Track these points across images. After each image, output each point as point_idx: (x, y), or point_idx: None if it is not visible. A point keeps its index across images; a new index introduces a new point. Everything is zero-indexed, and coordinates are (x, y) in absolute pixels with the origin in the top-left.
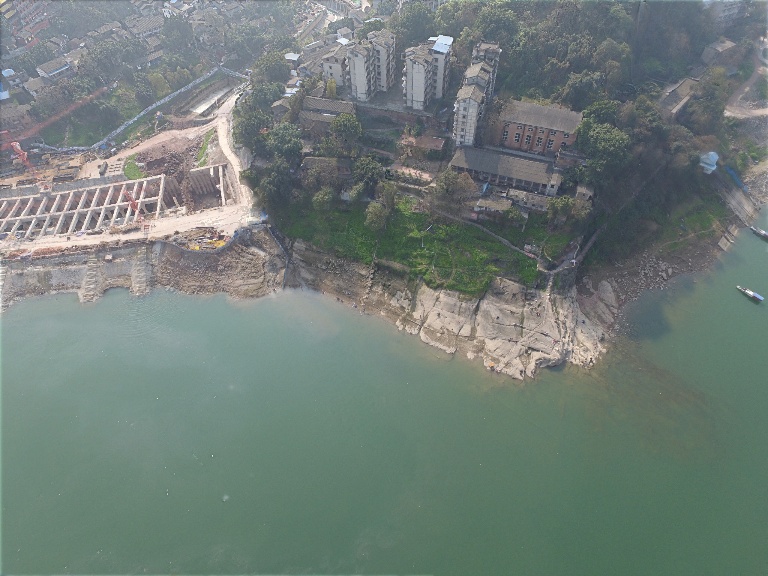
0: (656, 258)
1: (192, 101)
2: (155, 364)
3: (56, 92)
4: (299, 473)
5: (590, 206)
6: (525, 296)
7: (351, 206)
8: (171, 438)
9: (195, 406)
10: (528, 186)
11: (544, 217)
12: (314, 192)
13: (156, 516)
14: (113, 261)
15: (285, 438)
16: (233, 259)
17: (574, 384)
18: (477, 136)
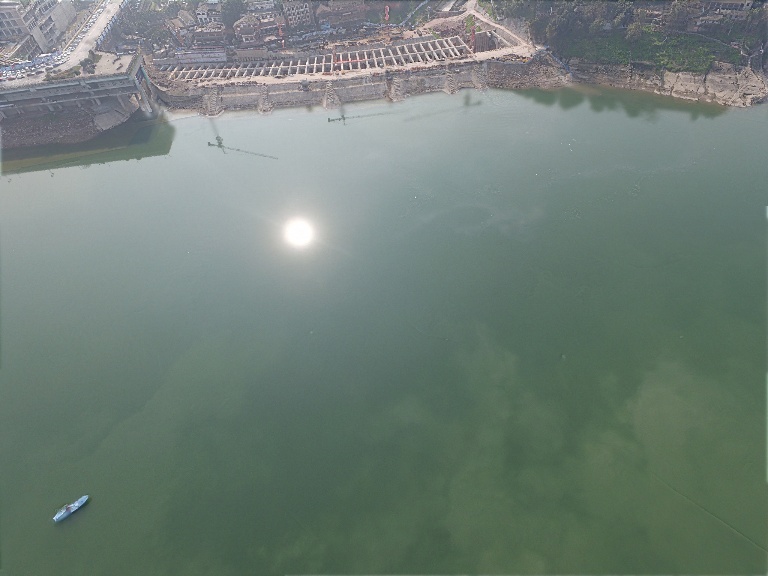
0: None
1: (440, 4)
2: (520, 112)
3: None
4: (639, 142)
5: None
6: (735, 70)
7: (609, 33)
8: (555, 135)
9: (558, 125)
10: (730, 8)
11: (743, 24)
12: (590, 23)
13: (570, 158)
14: (460, 73)
15: (620, 132)
16: (537, 68)
17: None
18: None
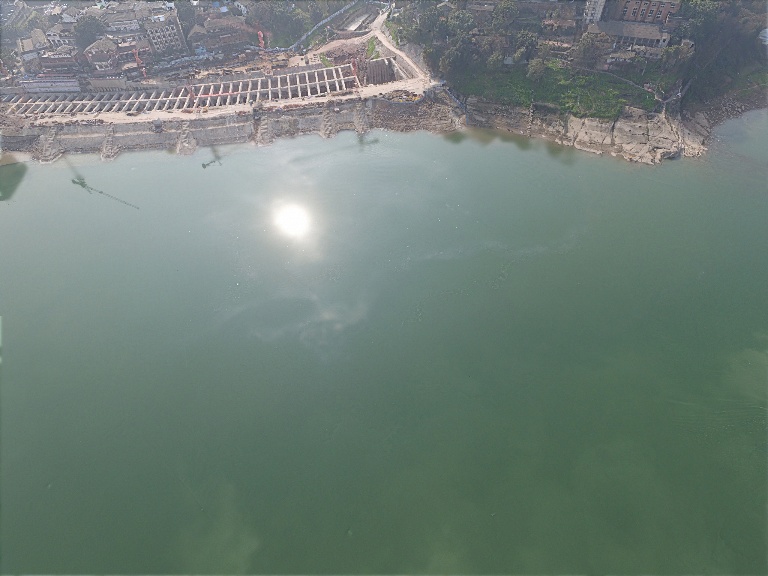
0: (733, 99)
1: (345, 22)
2: (396, 165)
3: (265, 5)
4: (520, 210)
5: (693, 50)
6: (647, 117)
7: (511, 68)
8: (427, 198)
9: (435, 184)
10: (645, 43)
11: (658, 63)
12: (487, 57)
13: (436, 231)
14: (340, 112)
15: (503, 196)
16: (427, 108)
17: (689, 166)
18: (602, 15)
